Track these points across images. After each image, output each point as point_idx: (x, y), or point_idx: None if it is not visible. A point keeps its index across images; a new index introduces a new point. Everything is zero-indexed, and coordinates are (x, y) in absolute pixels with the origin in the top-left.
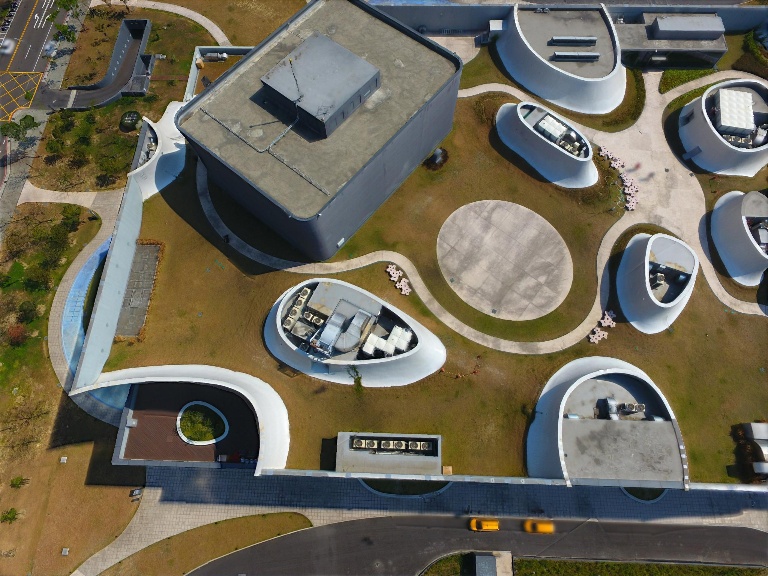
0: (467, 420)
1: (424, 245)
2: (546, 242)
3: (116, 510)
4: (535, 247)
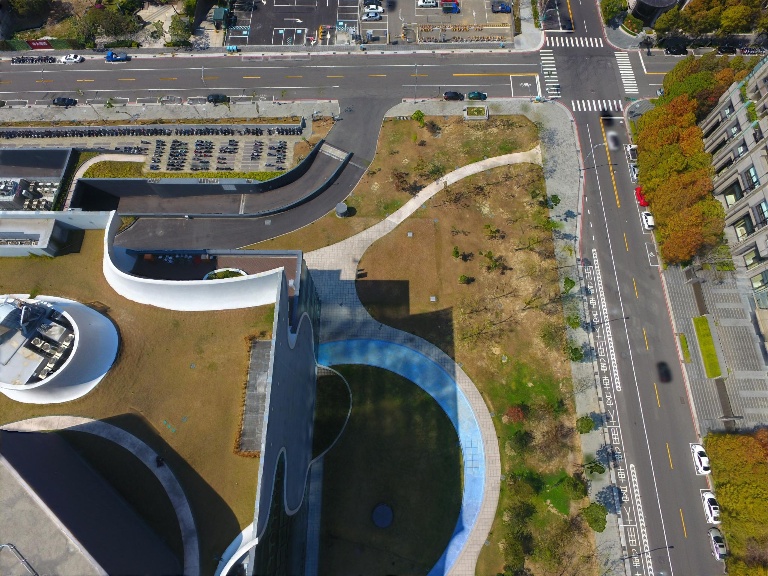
0: None
1: None
2: None
3: (376, 263)
4: None
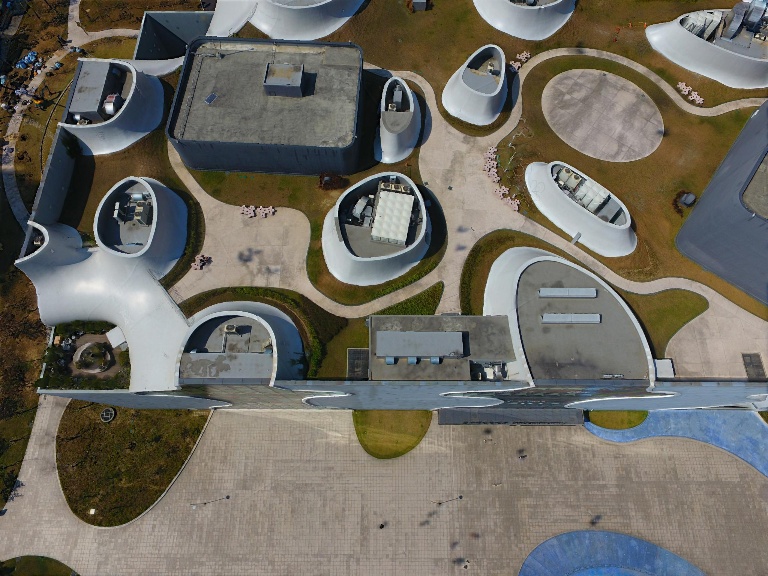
0: (617, 8)
1: (675, 123)
2: (566, 125)
3: None
4: (575, 121)
